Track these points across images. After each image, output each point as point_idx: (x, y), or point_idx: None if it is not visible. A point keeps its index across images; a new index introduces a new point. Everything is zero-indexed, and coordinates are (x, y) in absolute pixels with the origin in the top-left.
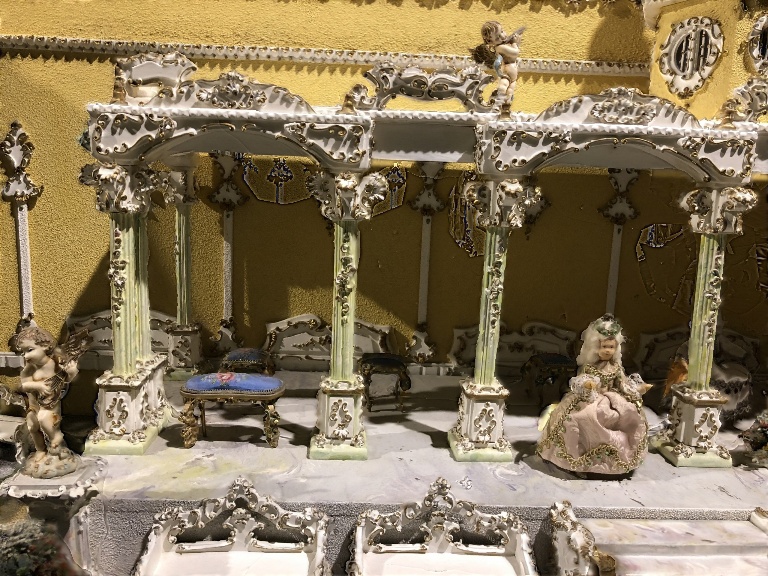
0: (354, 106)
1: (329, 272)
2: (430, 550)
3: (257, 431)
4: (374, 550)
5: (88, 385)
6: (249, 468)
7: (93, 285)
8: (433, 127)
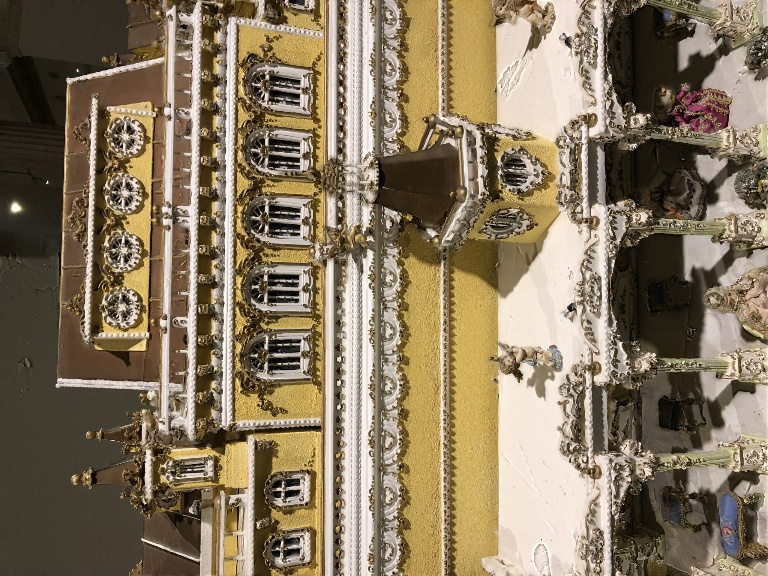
0: None
1: None
2: None
3: None
4: None
5: None
6: None
7: None
8: None
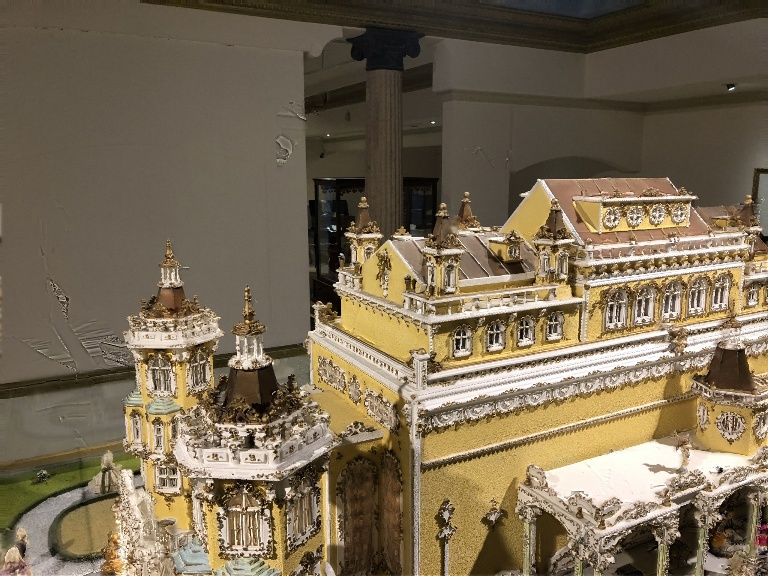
0: None
1: None
2: None
3: None
4: None
5: None
6: None
7: (475, 568)
8: None
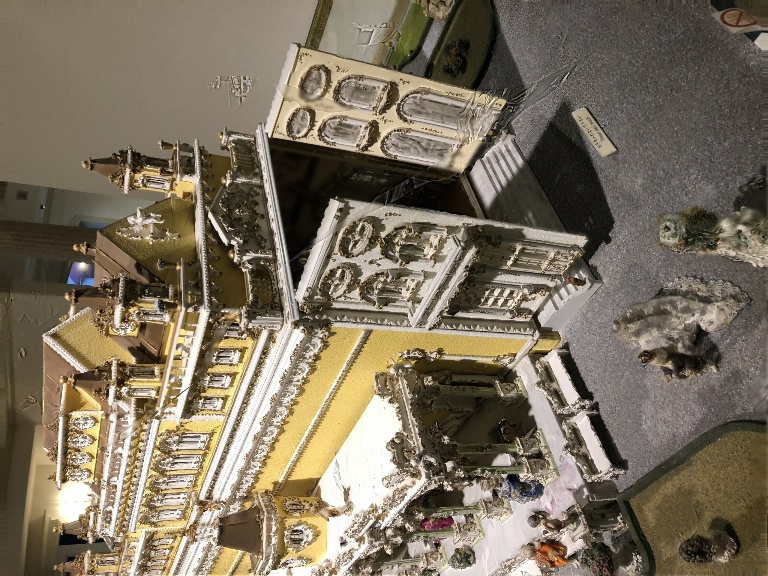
0: None
1: None
2: None
3: None
4: None
5: None
6: None
7: None
8: None
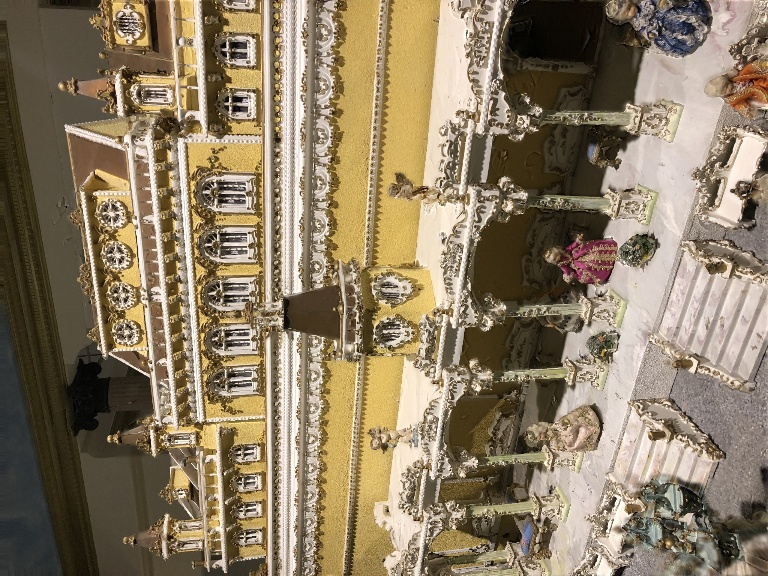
0: (417, 514)
1: (464, 438)
2: (613, 518)
3: (548, 519)
4: (608, 534)
5: (507, 527)
6: (565, 549)
7: (459, 528)
8: (426, 484)
